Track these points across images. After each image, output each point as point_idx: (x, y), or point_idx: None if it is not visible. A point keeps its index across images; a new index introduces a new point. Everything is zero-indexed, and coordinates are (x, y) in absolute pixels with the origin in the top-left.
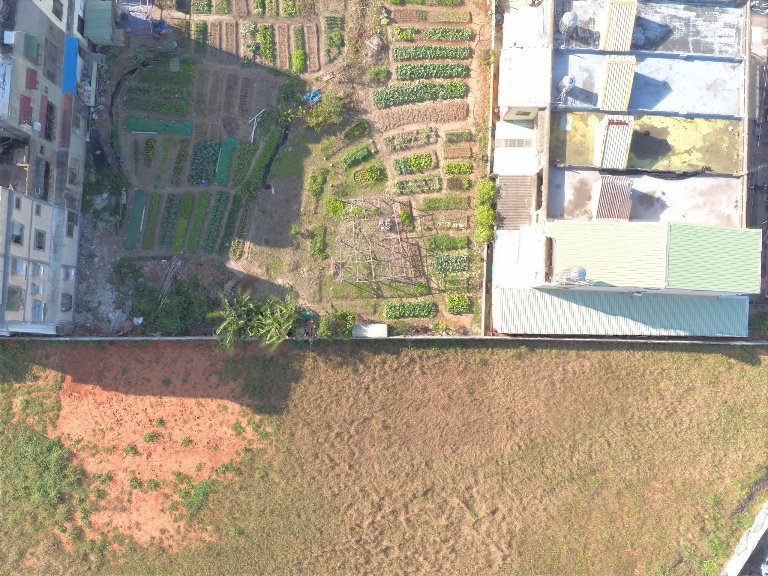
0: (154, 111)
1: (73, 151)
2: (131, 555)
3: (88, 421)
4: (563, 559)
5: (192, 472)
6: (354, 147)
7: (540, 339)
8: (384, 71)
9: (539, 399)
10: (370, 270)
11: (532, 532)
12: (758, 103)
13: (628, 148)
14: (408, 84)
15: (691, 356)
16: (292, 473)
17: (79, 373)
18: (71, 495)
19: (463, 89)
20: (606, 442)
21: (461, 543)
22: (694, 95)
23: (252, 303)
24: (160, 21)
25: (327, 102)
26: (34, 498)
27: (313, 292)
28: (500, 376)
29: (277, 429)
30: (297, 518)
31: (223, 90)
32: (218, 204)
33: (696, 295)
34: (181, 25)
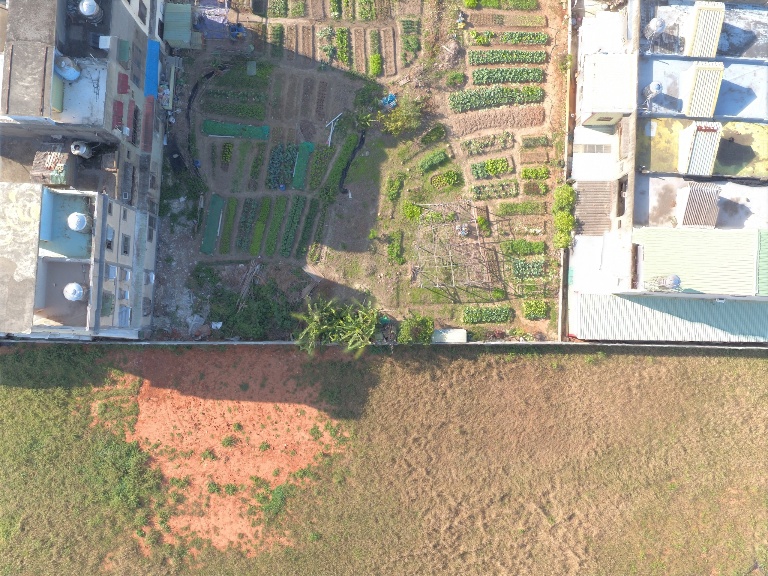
0: (231, 115)
1: (153, 155)
2: (210, 559)
3: (166, 425)
4: (639, 565)
5: (270, 477)
6: (431, 152)
7: (618, 345)
8: (461, 75)
9: (615, 405)
10: (447, 275)
11: (608, 538)
12: None
13: (715, 155)
14: (485, 89)
15: (766, 362)
16: (370, 478)
17: (157, 377)
18: (150, 499)
19: (540, 94)
20: (682, 448)
21: (538, 548)
22: None
23: (333, 308)
24: (237, 24)
25: (406, 107)
26: (113, 502)
27: (390, 297)
28: (577, 382)
29: (355, 434)
30: (375, 523)
31: (300, 94)
32: (295, 208)
33: None
34: (258, 28)
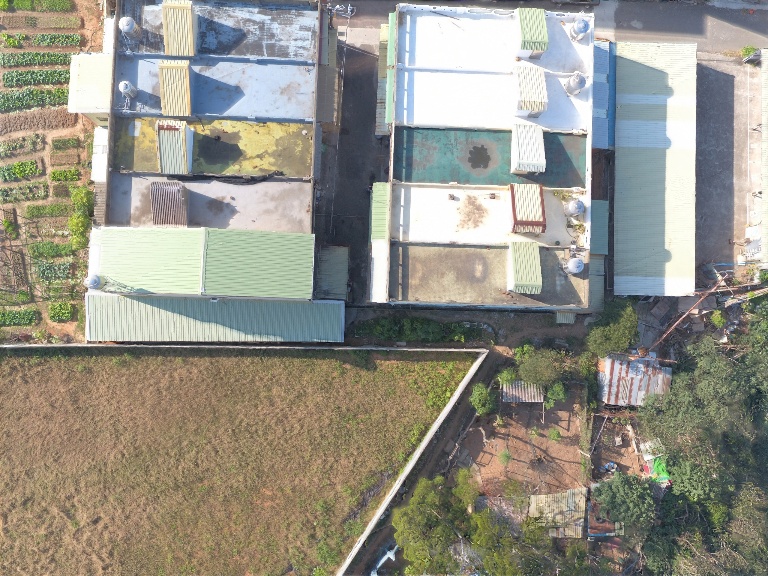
0: None
1: None
2: None
3: None
4: (167, 568)
5: None
6: None
7: None
8: None
9: (144, 407)
10: None
11: (136, 541)
12: (336, 106)
13: (184, 153)
14: (15, 91)
15: (303, 362)
16: None
17: None
18: None
19: None
20: (212, 449)
21: (60, 553)
22: (267, 99)
23: None
24: None
25: None
26: None
27: None
28: (104, 384)
29: None
30: None
31: None
32: None
33: (289, 300)
34: None
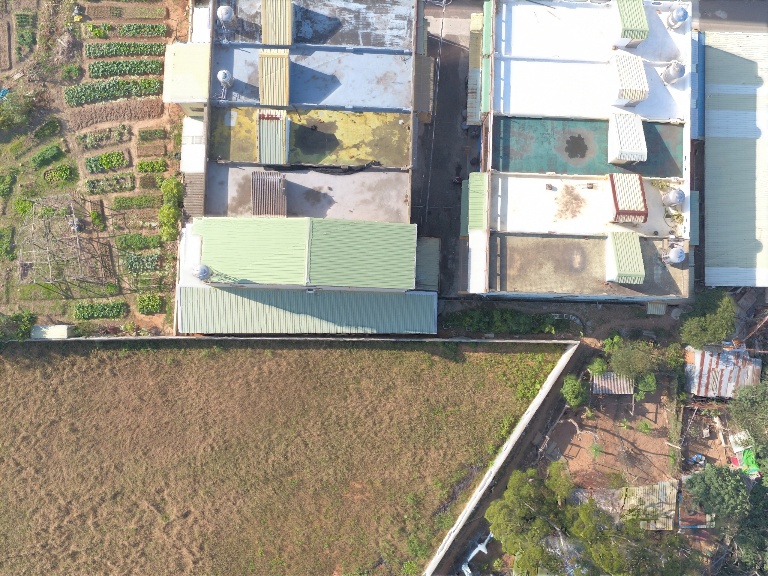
0: None
1: None
2: None
3: None
4: (258, 562)
5: None
6: (45, 146)
7: None
8: (76, 69)
9: (234, 399)
10: (59, 271)
11: (226, 535)
12: (432, 96)
13: (284, 143)
14: (101, 82)
15: (392, 354)
16: None
17: None
18: None
19: (157, 86)
20: (302, 442)
21: (151, 547)
22: (363, 88)
23: None
24: None
25: (7, 101)
26: None
27: None
28: (193, 376)
29: None
30: None
31: None
32: None
33: (382, 292)
34: None
